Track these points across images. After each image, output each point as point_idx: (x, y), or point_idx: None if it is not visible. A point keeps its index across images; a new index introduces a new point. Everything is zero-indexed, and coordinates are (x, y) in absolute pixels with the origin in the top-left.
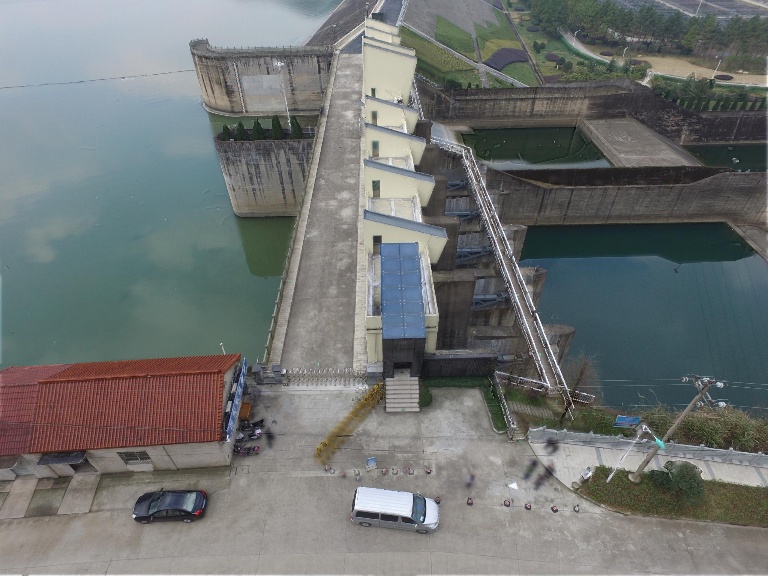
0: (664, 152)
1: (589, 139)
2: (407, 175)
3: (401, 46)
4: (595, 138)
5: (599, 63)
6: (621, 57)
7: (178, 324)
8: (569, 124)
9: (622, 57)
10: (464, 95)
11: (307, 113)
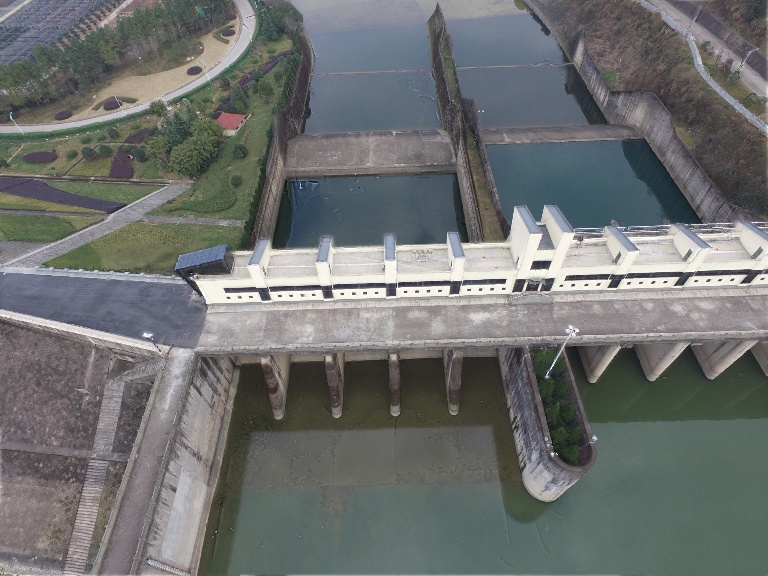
0: (364, 142)
1: (319, 177)
2: (758, 231)
3: (520, 213)
4: (326, 172)
5: (99, 127)
6: (180, 106)
7: (759, 510)
8: (283, 182)
9: (181, 106)
10: (255, 240)
11: (221, 448)
